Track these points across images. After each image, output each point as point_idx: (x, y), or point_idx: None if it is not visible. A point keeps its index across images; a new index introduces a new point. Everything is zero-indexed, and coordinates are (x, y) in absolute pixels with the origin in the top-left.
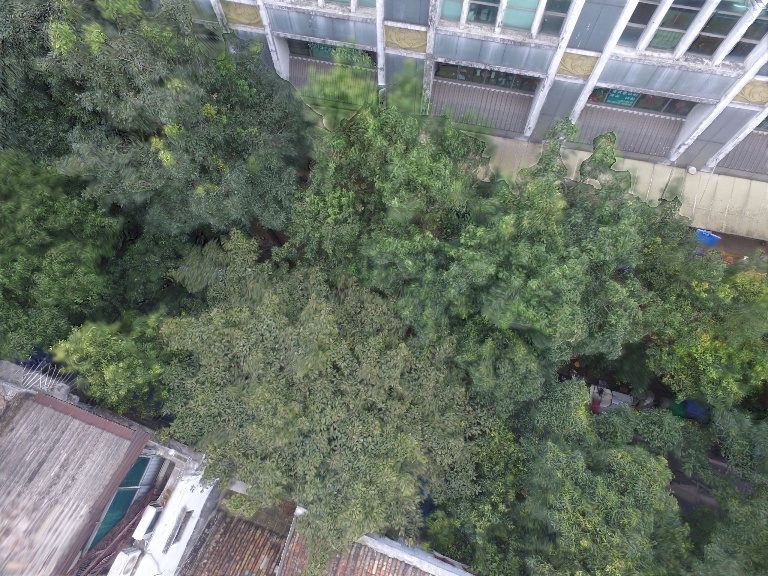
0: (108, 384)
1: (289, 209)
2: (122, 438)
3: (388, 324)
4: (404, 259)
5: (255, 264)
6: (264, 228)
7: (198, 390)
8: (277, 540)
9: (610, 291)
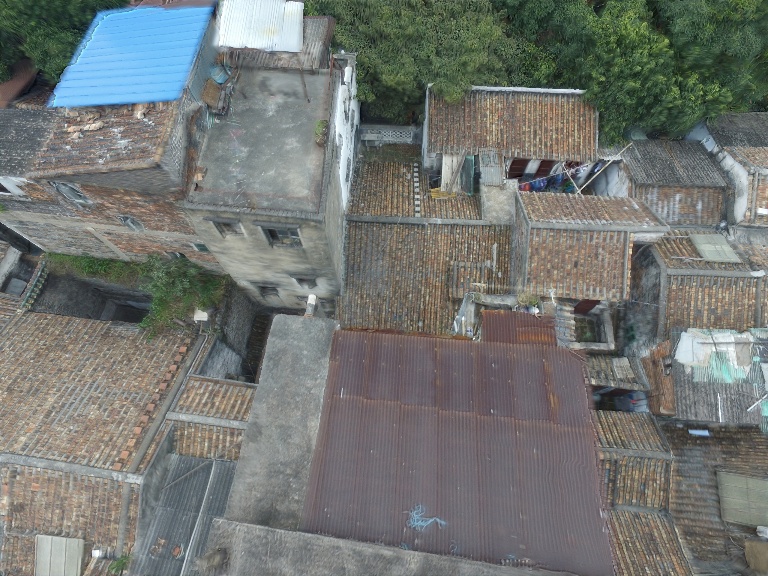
0: None
1: None
2: (322, 18)
3: None
4: None
5: None
6: None
7: (340, 33)
8: (406, 164)
9: None
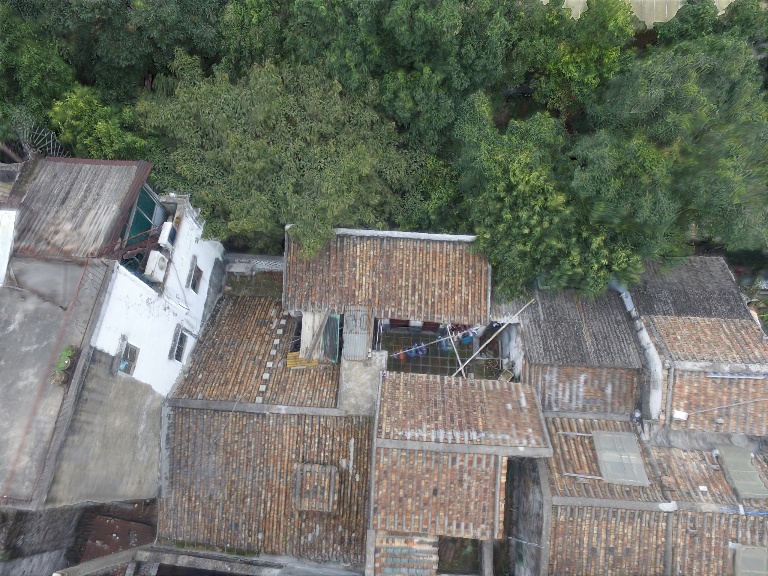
0: (105, 143)
1: (218, 23)
2: (129, 165)
3: (322, 84)
4: (318, 7)
5: (201, 80)
6: (201, 47)
7: (180, 161)
8: (280, 300)
9: (479, 5)
